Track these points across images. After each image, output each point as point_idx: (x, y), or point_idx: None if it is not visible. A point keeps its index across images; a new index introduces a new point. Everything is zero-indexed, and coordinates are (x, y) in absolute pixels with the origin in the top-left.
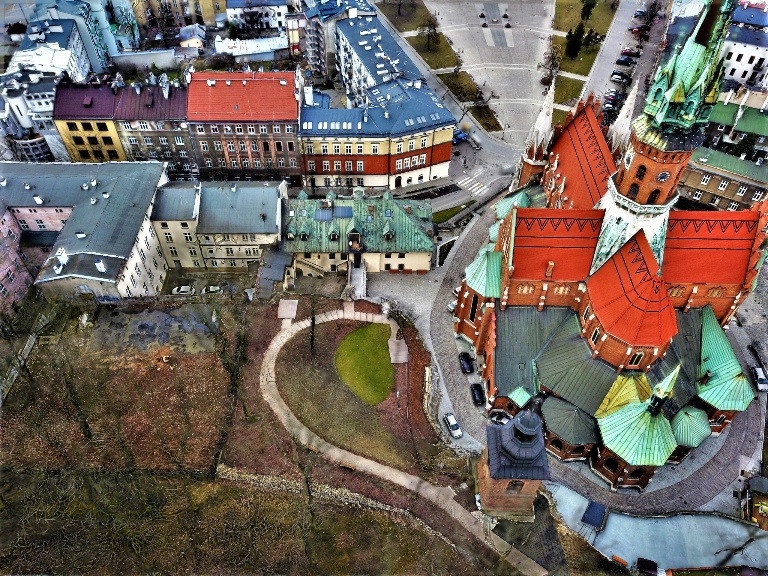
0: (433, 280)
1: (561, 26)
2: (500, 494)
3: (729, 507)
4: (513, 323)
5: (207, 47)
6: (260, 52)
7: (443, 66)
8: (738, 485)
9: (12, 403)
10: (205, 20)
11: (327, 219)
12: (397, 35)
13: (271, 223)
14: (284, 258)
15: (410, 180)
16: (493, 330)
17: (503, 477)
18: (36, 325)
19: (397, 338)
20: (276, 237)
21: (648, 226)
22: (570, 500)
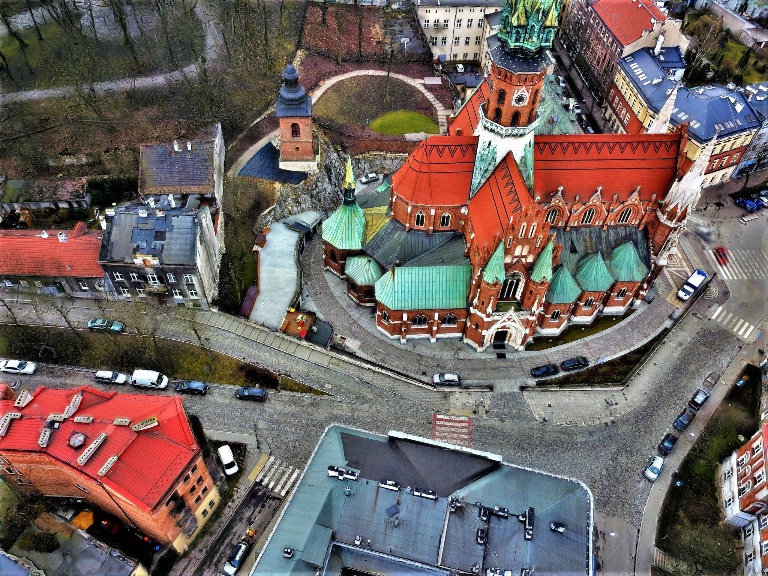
0: None
1: None
2: None
3: None
4: None
5: None
6: None
7: None
8: None
9: (345, 6)
10: None
11: None
12: None
13: None
14: None
15: None
16: None
17: (278, 100)
18: (393, 1)
19: None
20: None
21: (481, 136)
22: (311, 219)
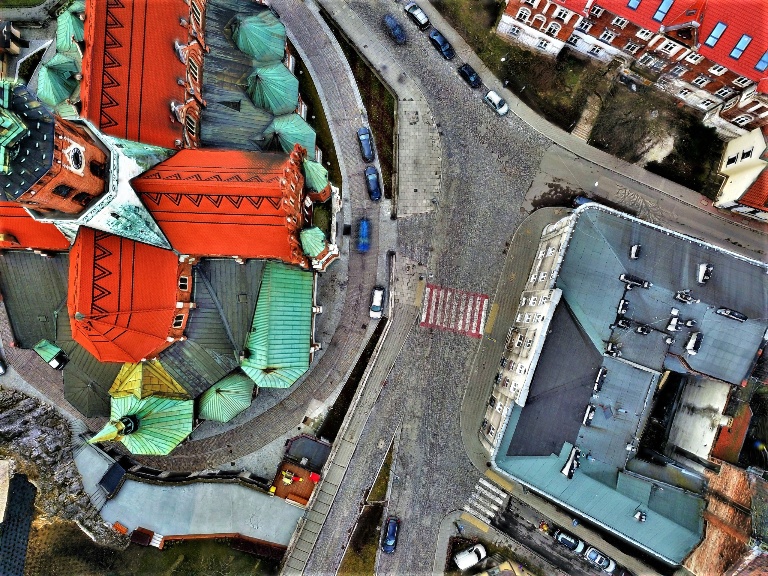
0: None
1: None
2: None
3: (275, 457)
4: (19, 270)
5: None
6: None
7: None
8: (295, 433)
9: None
10: None
11: None
12: None
13: None
14: None
15: None
16: None
17: None
18: None
19: None
20: None
21: (88, 223)
22: (94, 460)
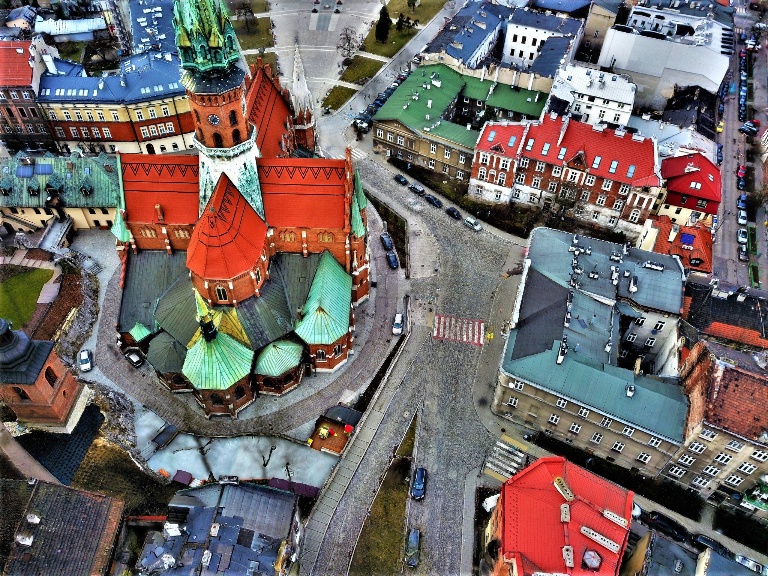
0: None
1: None
2: (16, 403)
3: (311, 433)
4: (144, 265)
5: None
6: (78, 32)
7: (254, 47)
8: None
9: None
10: (40, 3)
11: (28, 175)
12: None
13: None
14: None
15: (164, 148)
16: (122, 271)
17: None
18: None
19: (55, 282)
20: None
21: (228, 169)
22: (152, 423)
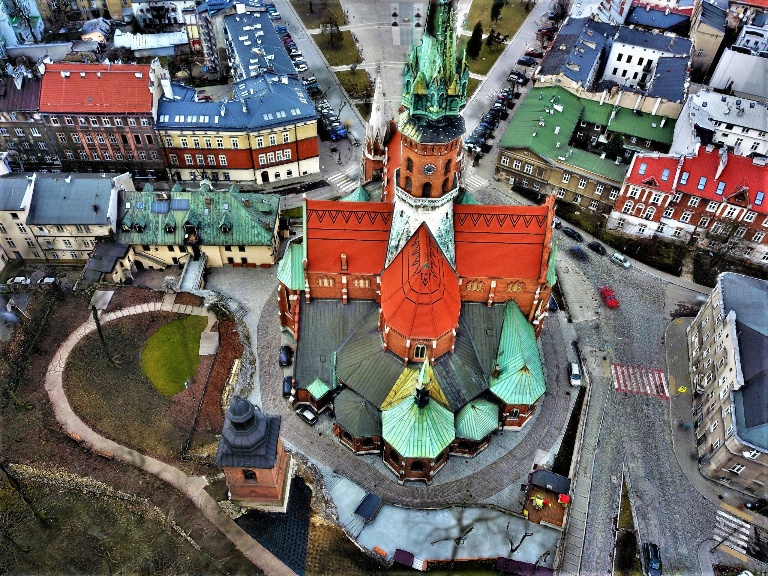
0: (275, 274)
1: (471, 26)
2: (239, 483)
3: (513, 500)
4: (317, 316)
5: (110, 41)
6: (159, 47)
7: (343, 63)
8: None
9: None
10: (112, 14)
11: (163, 211)
12: (304, 32)
13: (103, 214)
14: (118, 250)
15: (278, 175)
16: (296, 322)
17: (225, 465)
18: None
19: (212, 330)
20: (109, 229)
21: (430, 219)
22: (349, 492)
